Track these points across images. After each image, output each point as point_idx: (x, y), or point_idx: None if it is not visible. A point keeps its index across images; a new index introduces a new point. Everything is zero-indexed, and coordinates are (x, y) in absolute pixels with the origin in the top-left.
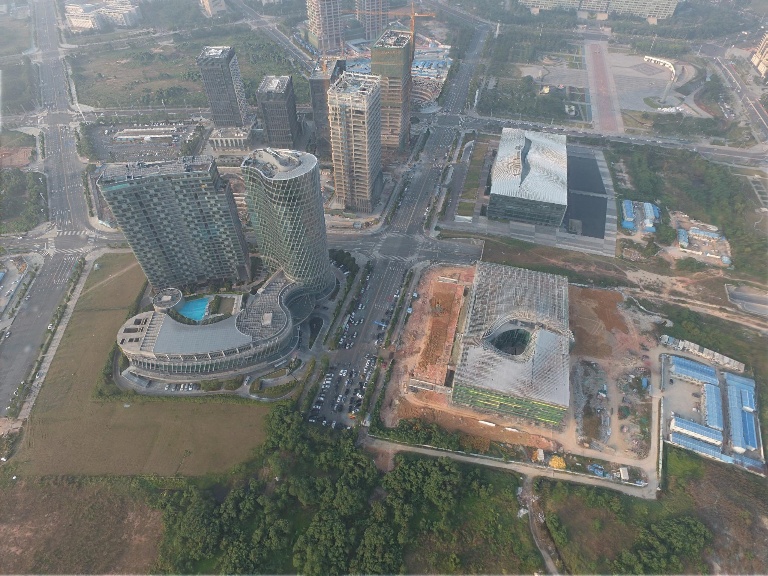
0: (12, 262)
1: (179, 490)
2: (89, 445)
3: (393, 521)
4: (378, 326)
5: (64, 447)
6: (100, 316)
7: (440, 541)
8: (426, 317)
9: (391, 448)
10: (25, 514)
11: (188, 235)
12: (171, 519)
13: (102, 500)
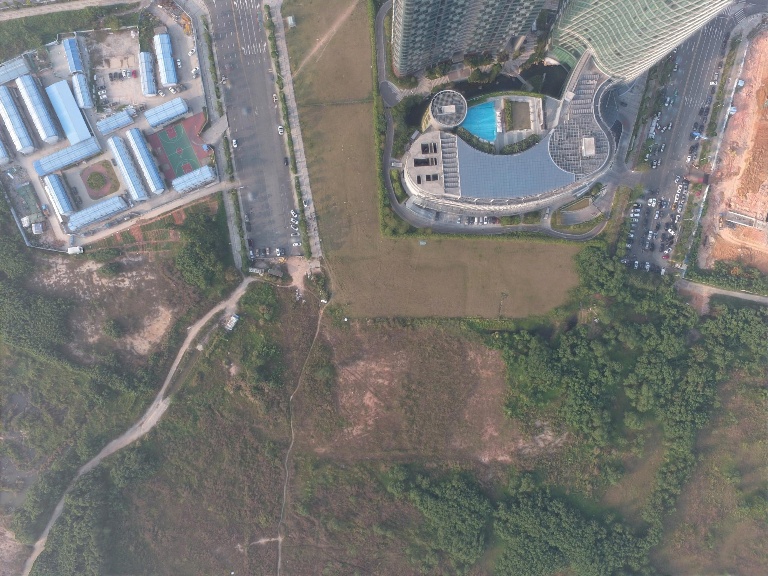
0: (163, 10)
1: (507, 331)
2: (402, 287)
3: (710, 361)
4: (690, 134)
5: (378, 289)
6: (337, 115)
7: (748, 376)
8: (750, 120)
9: (705, 291)
10: (375, 353)
11: (479, 6)
12: (512, 359)
13: (441, 342)
